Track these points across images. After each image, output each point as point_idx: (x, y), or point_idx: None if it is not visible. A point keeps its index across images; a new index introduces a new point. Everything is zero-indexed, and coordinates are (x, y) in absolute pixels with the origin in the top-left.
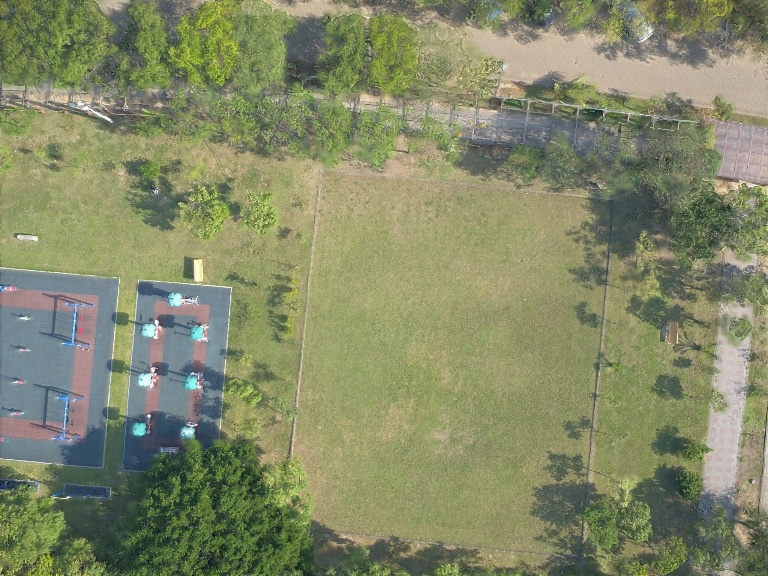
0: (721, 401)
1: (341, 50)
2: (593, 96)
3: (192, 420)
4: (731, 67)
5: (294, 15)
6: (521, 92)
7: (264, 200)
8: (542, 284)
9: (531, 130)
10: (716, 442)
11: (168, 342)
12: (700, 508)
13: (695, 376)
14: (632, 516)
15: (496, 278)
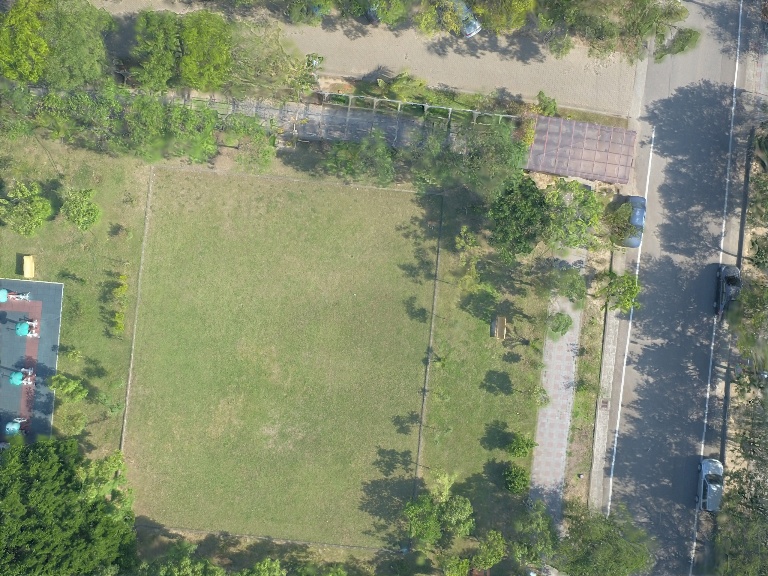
0: (543, 396)
1: (151, 46)
2: (423, 91)
3: (24, 416)
4: (561, 62)
5: (125, 11)
6: (351, 87)
7: (84, 196)
8: (372, 279)
9: (360, 125)
10: (545, 437)
11: (0, 338)
12: (529, 503)
13: (524, 371)
14: (451, 510)
15: (326, 273)
